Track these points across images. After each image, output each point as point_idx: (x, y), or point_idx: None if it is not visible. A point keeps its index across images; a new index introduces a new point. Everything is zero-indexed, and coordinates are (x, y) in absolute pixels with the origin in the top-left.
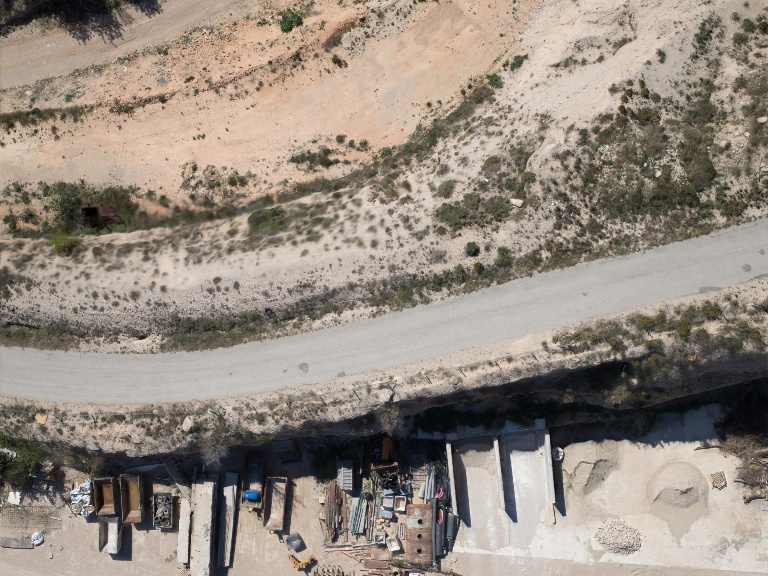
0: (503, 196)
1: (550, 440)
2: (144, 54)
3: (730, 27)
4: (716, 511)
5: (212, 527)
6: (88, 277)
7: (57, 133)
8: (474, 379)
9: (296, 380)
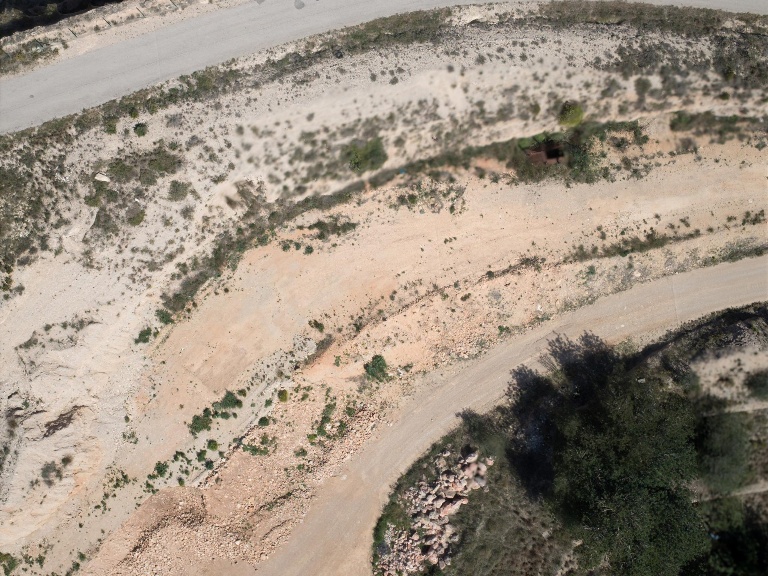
0: (118, 184)
1: None
2: (524, 326)
3: None
4: None
5: None
6: (535, 77)
7: (600, 233)
8: (129, 7)
9: None
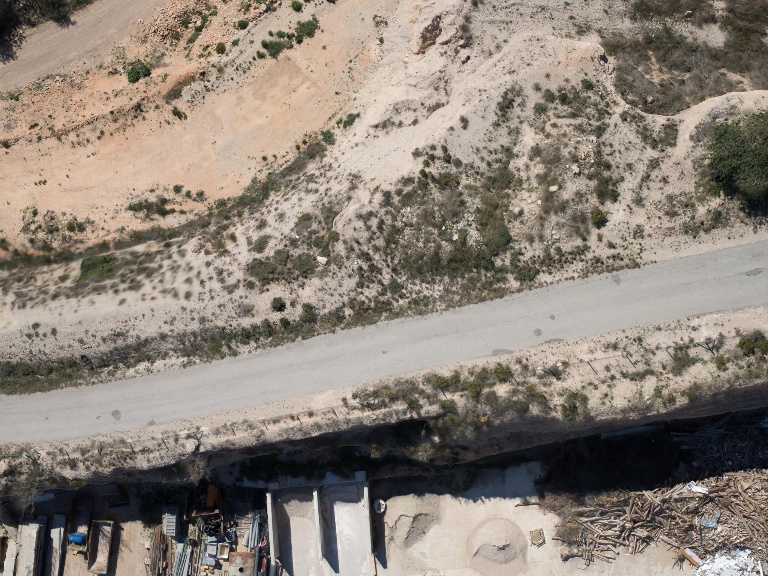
0: (311, 253)
1: (373, 492)
2: None
3: (532, 97)
4: (534, 568)
5: (36, 569)
6: None
7: None
8: (276, 432)
9: (108, 427)
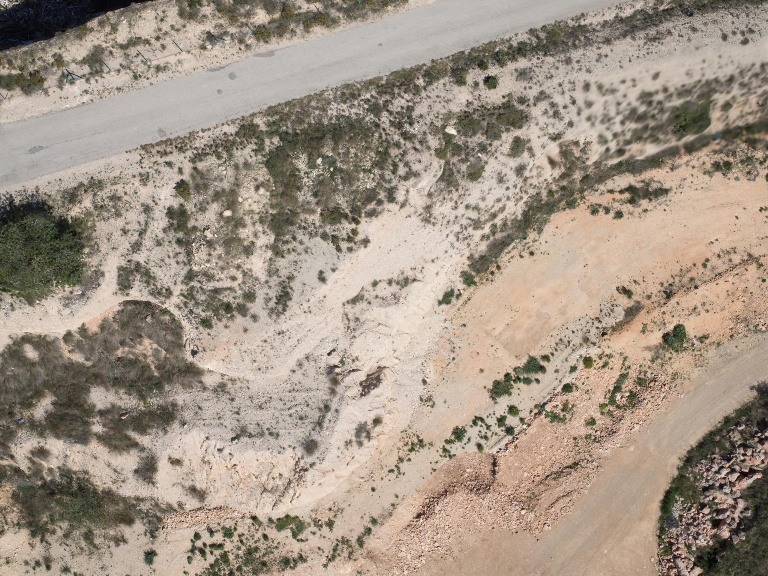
0: (464, 138)
1: None
2: None
3: (259, 309)
4: None
5: None
6: None
7: None
8: None
9: None
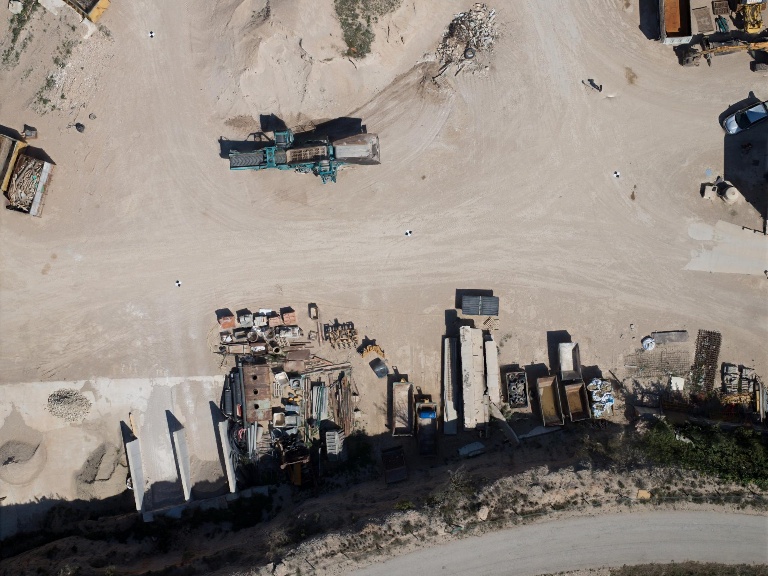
0: None
1: None
2: None
3: None
4: None
5: None
6: None
7: None
8: None
9: (375, 571)
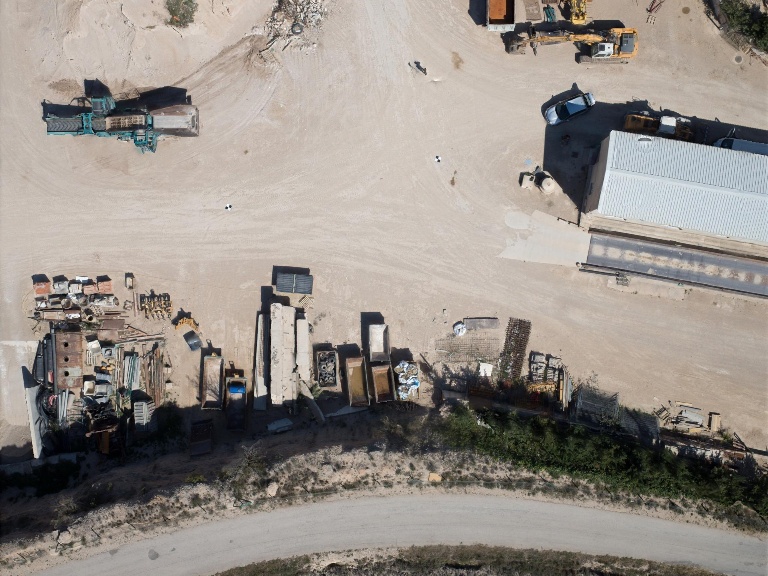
0: None
1: None
2: None
3: None
4: None
5: None
6: None
7: None
8: None
9: (161, 542)
